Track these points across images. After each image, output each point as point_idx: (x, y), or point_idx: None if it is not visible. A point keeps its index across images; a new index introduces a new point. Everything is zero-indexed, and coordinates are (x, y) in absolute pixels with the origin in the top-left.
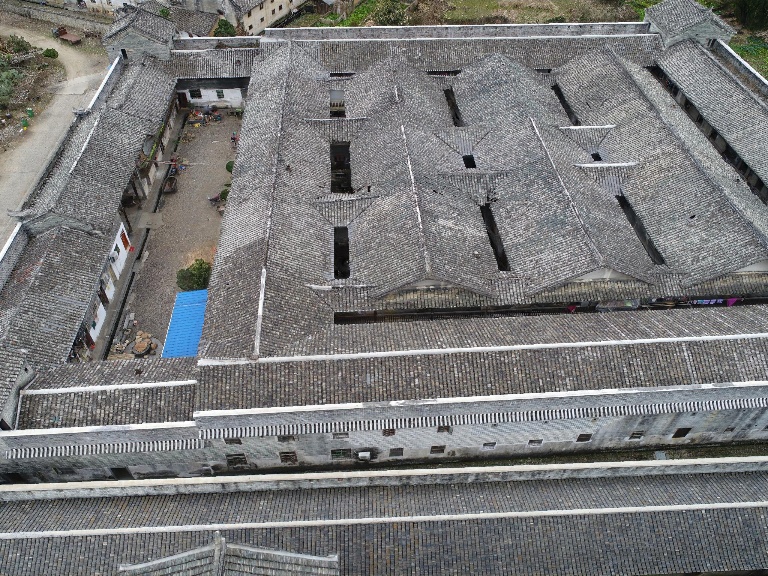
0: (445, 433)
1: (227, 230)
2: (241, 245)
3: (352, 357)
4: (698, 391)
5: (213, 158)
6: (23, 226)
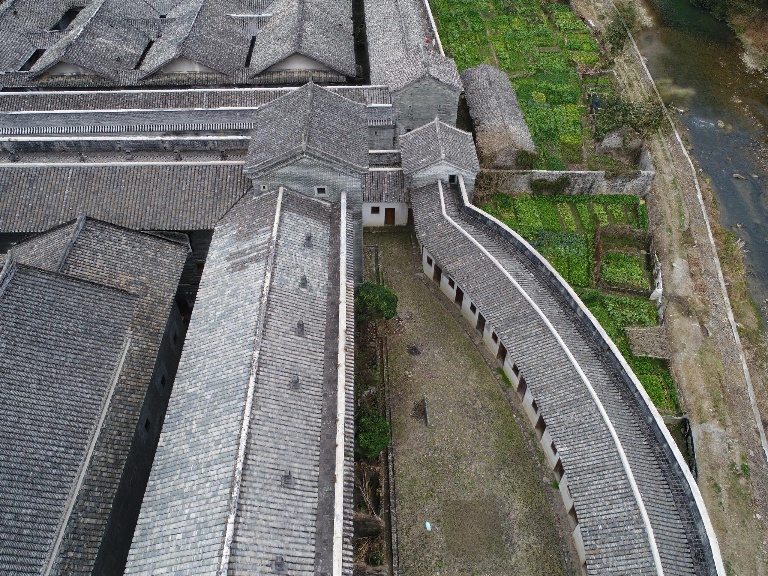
0: None
1: None
2: None
3: None
4: (195, 113)
5: None
6: None
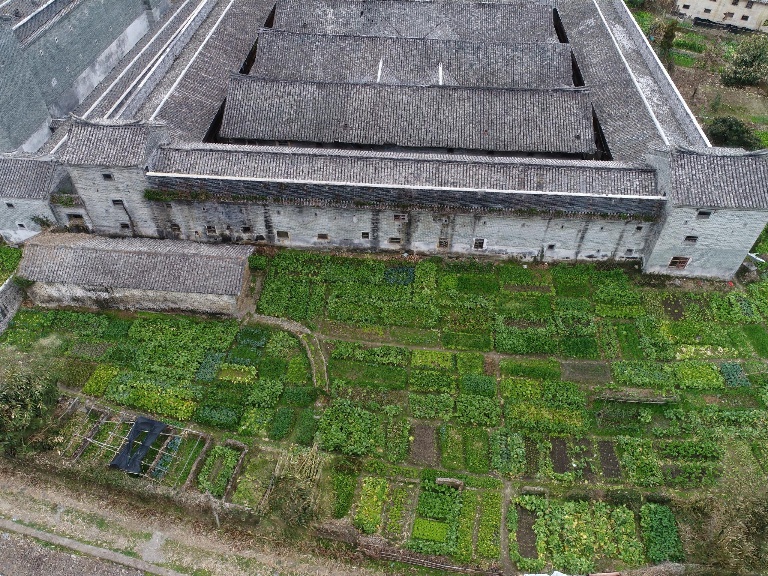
0: None
1: None
2: None
3: None
4: None
5: None
6: None
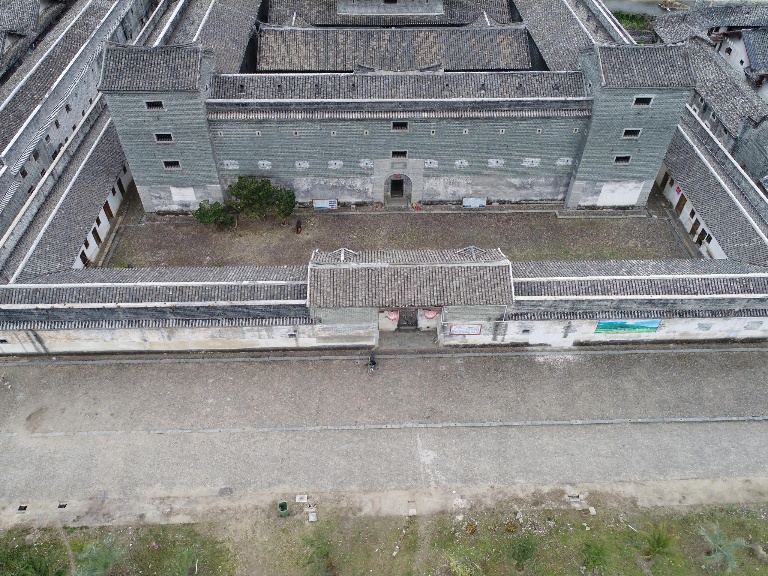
0: (69, 113)
1: None
2: None
3: (3, 107)
4: None
5: None
6: None
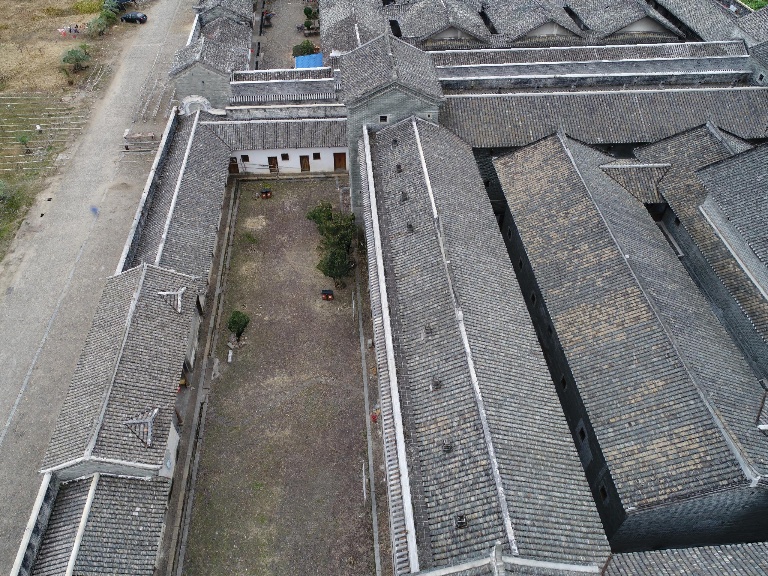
0: None
1: (324, 19)
2: (337, 21)
3: None
4: (601, 65)
5: (291, 11)
6: (199, 17)
